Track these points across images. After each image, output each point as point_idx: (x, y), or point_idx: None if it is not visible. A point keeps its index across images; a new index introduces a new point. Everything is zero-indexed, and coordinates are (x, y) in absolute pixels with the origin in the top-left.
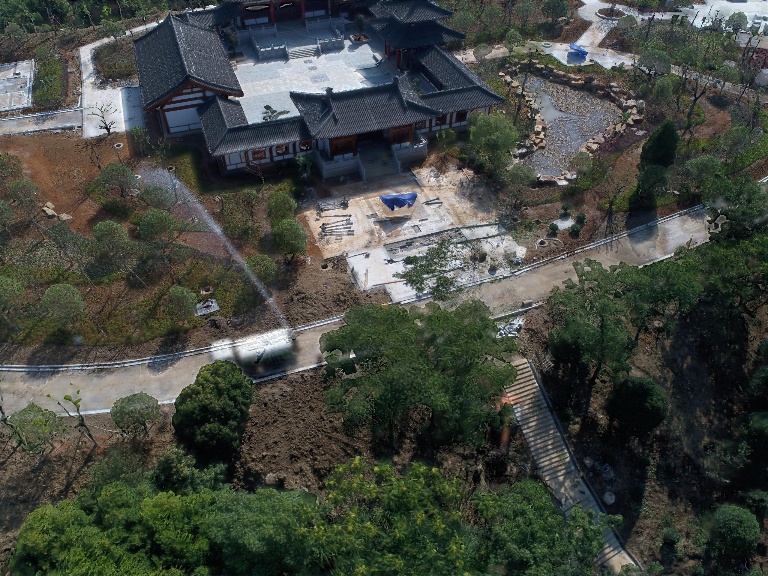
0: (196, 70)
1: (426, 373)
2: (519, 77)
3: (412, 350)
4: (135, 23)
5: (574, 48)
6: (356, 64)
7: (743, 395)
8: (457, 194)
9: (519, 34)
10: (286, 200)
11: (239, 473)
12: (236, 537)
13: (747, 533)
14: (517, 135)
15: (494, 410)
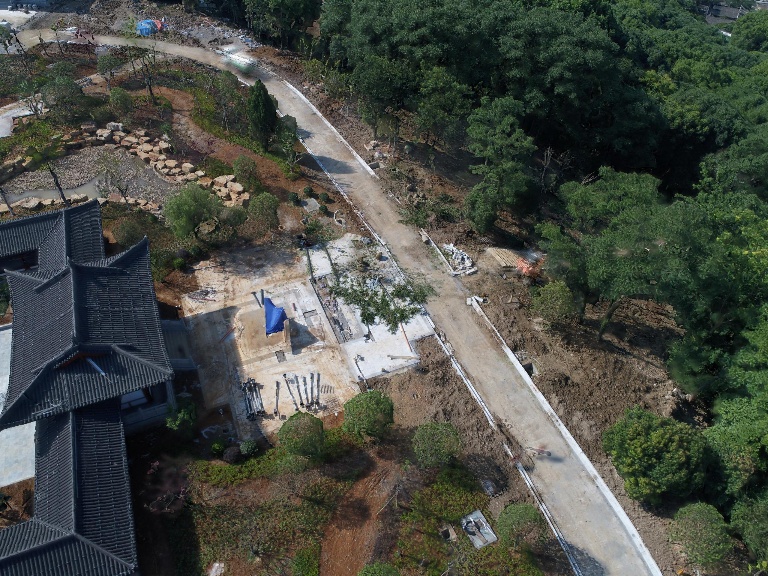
0: None
1: None
2: None
3: None
4: None
5: None
6: None
7: None
8: (247, 277)
9: None
10: None
11: None
12: None
13: None
14: None
15: None
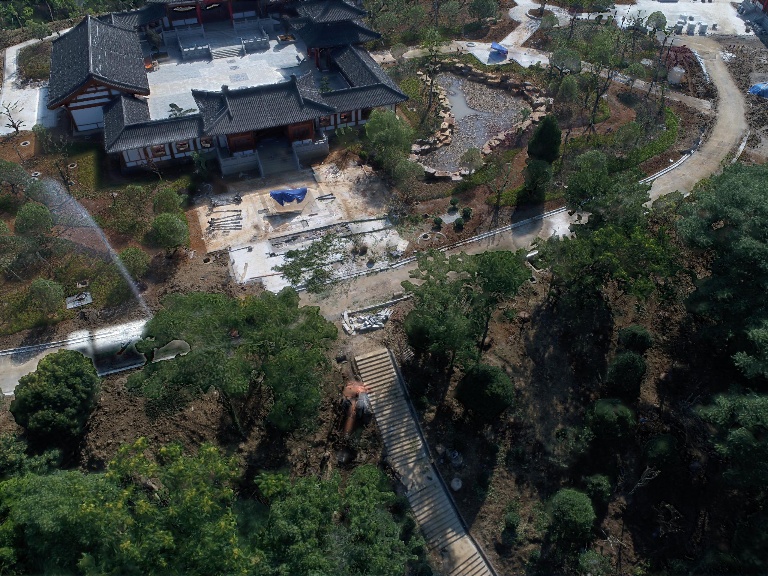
0: (103, 69)
1: (220, 356)
2: (438, 76)
3: (213, 335)
4: (66, 24)
5: (495, 47)
6: (278, 64)
7: (602, 383)
8: (352, 190)
9: (438, 34)
10: (169, 195)
11: (84, 460)
12: (34, 518)
13: (578, 516)
14: (411, 131)
15: (349, 399)
